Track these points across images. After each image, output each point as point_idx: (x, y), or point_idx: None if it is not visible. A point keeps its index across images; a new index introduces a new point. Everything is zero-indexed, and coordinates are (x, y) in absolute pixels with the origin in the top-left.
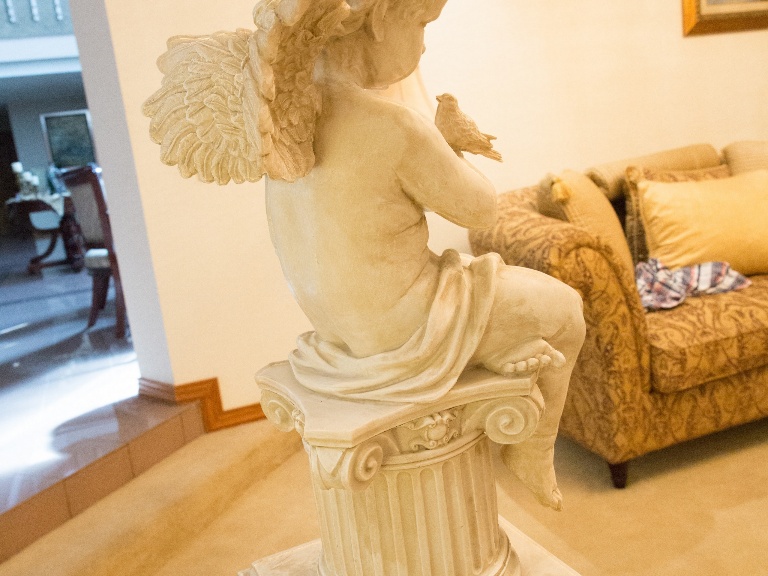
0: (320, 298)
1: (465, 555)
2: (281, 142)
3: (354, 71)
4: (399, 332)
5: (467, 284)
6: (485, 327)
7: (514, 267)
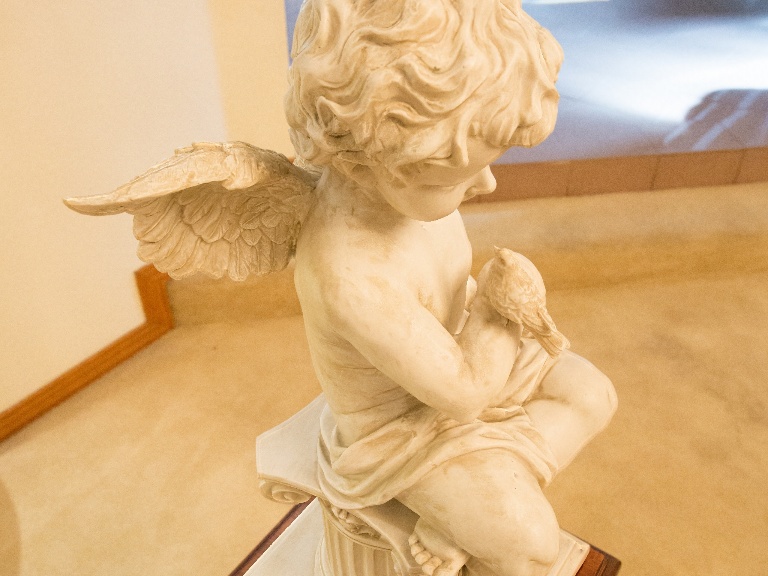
0: None
1: None
2: (244, 241)
3: (360, 194)
4: None
5: (409, 449)
6: None
7: (483, 469)
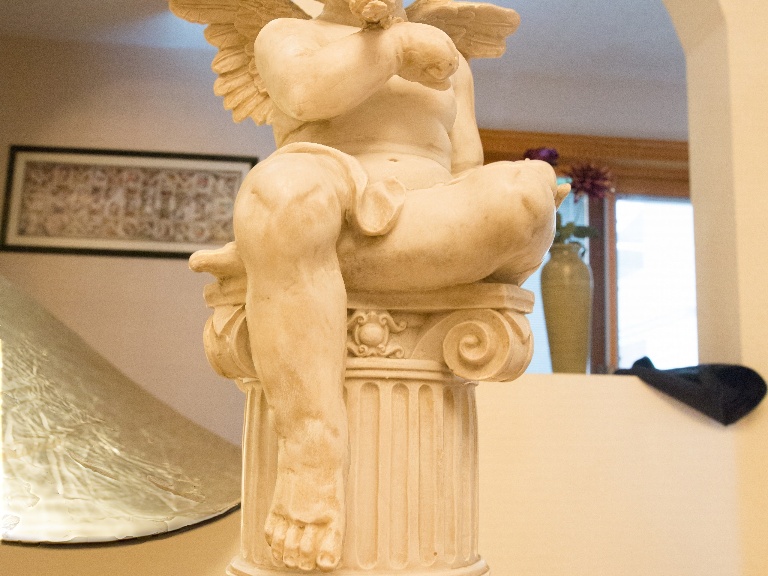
0: None
1: None
2: None
3: None
4: None
5: None
6: None
7: None
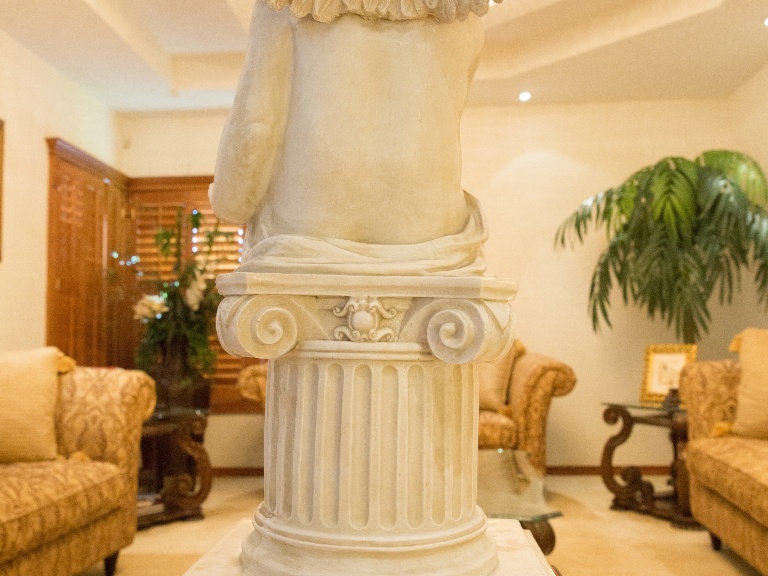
0: (405, 164)
1: None
2: None
3: None
4: (457, 218)
5: None
6: None
7: None
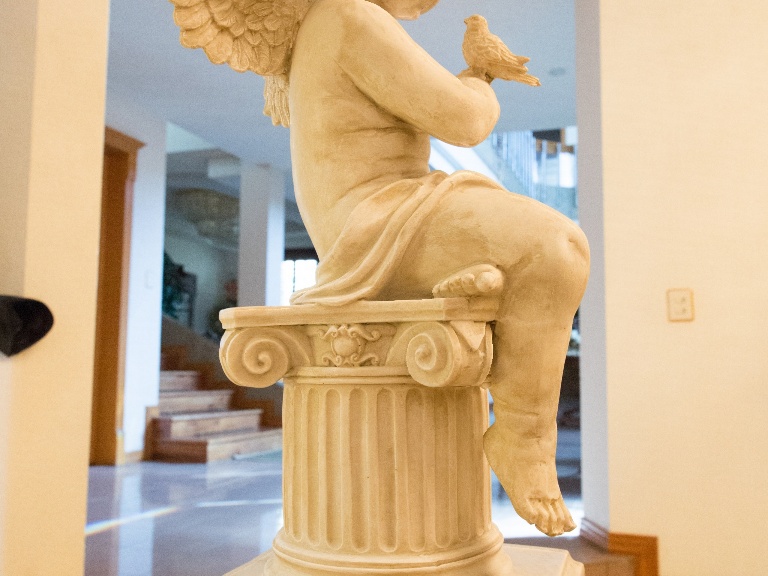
0: None
1: (369, 516)
2: (246, 41)
3: None
4: (337, 236)
5: (419, 194)
6: (412, 235)
7: (496, 189)
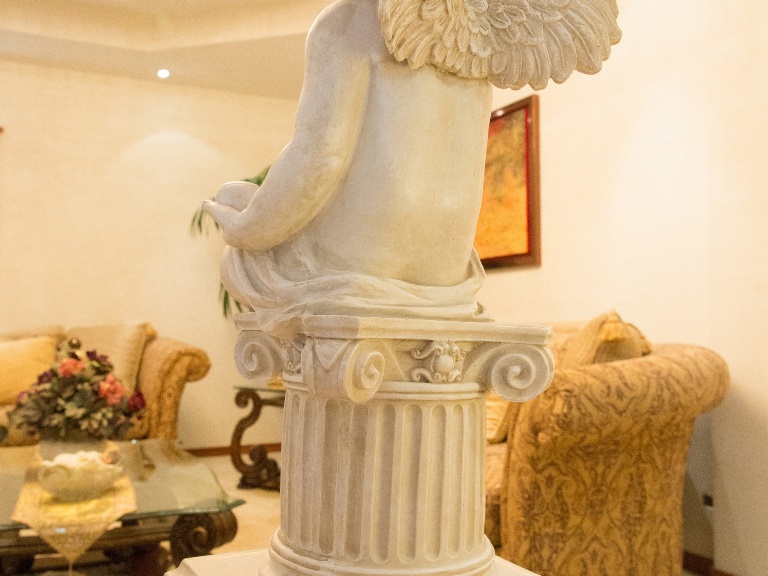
0: (461, 213)
1: None
2: None
3: None
4: None
5: None
6: None
7: None
